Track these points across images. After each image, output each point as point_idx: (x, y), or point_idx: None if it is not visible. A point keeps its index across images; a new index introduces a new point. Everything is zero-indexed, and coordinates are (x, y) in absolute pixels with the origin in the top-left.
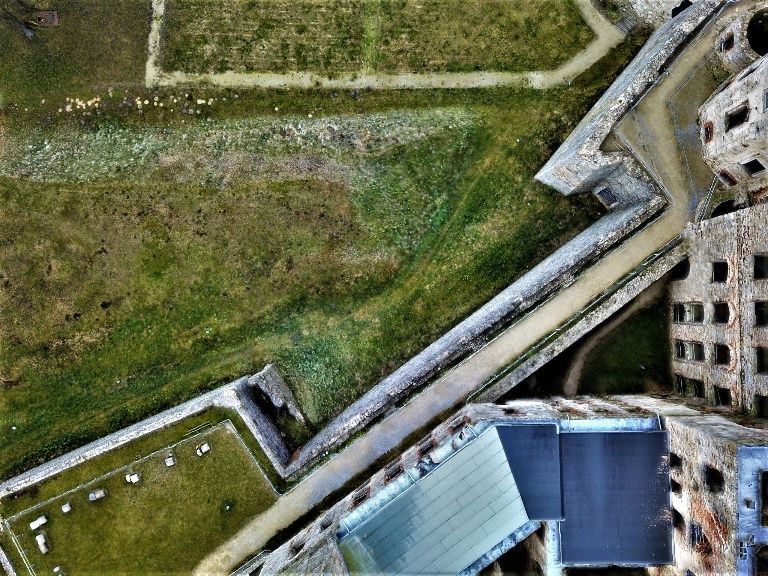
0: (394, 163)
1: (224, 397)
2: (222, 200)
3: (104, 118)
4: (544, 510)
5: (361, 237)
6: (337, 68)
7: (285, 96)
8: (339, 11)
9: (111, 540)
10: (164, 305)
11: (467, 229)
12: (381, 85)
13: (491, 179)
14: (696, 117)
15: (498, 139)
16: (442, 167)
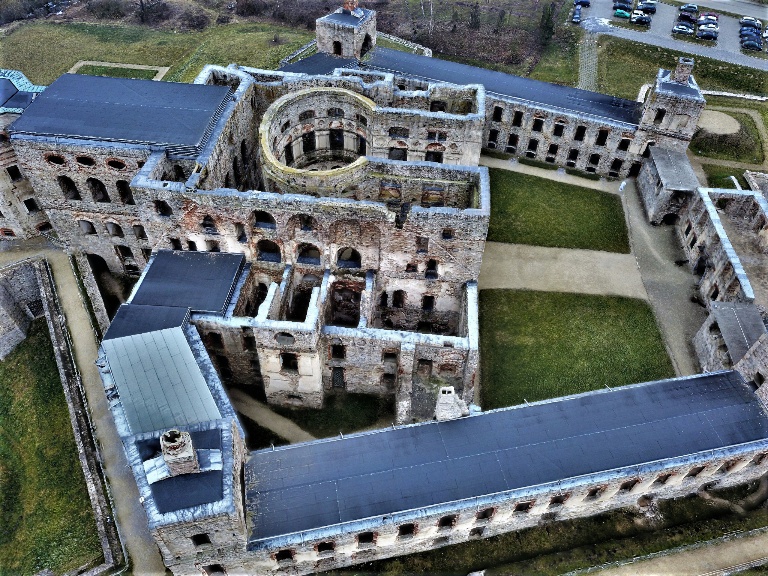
0: None
1: None
2: None
3: None
4: (177, 317)
5: None
6: None
7: None
8: None
9: None
10: None
11: (11, 412)
12: None
13: None
14: None
15: None
16: None
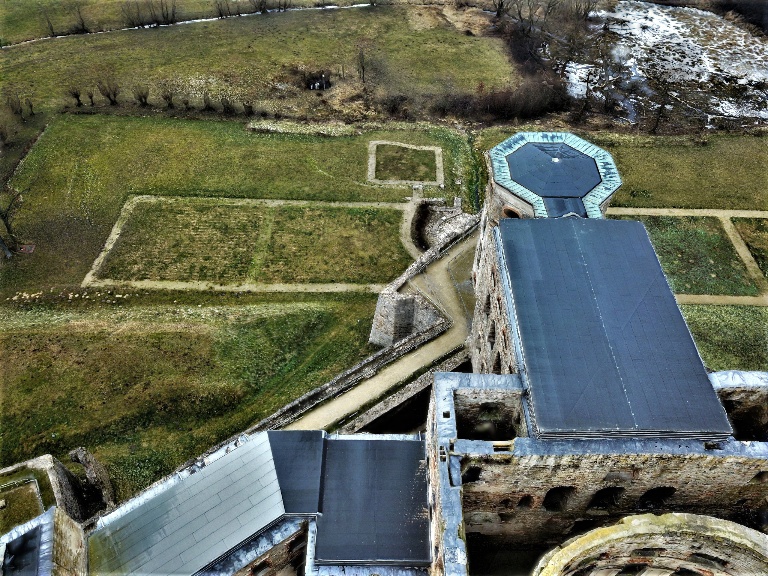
0: (255, 328)
1: (40, 460)
2: (107, 343)
3: (39, 304)
4: (301, 503)
5: (214, 370)
6: (228, 279)
7: (184, 294)
8: (237, 249)
9: None
10: (24, 415)
11: (309, 375)
12: (259, 289)
13: (335, 344)
14: (470, 277)
15: (343, 320)
16: (294, 333)
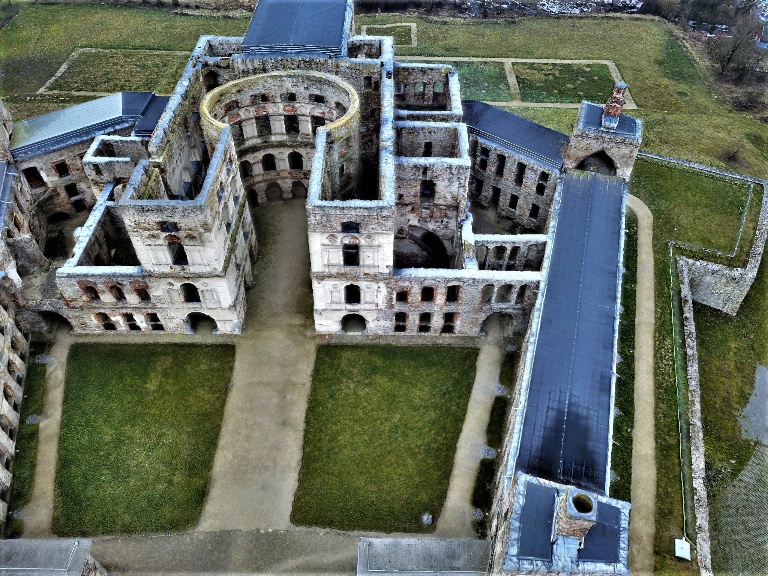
0: None
1: None
2: None
3: (6, 101)
4: None
5: None
6: None
7: None
8: None
9: None
10: None
11: None
12: None
13: None
14: None
15: None
16: None
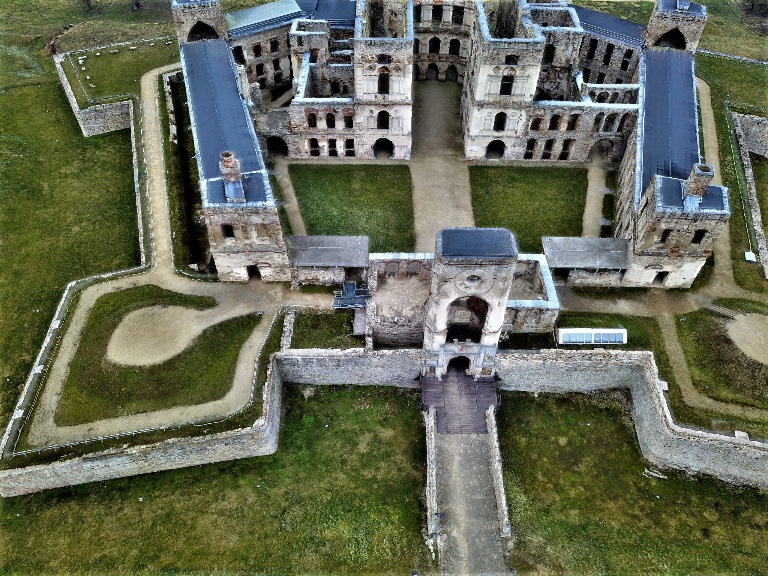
0: None
1: None
2: None
3: None
4: None
5: None
6: None
7: None
8: None
9: (114, 62)
10: None
11: None
12: None
13: None
14: None
15: None
16: None
